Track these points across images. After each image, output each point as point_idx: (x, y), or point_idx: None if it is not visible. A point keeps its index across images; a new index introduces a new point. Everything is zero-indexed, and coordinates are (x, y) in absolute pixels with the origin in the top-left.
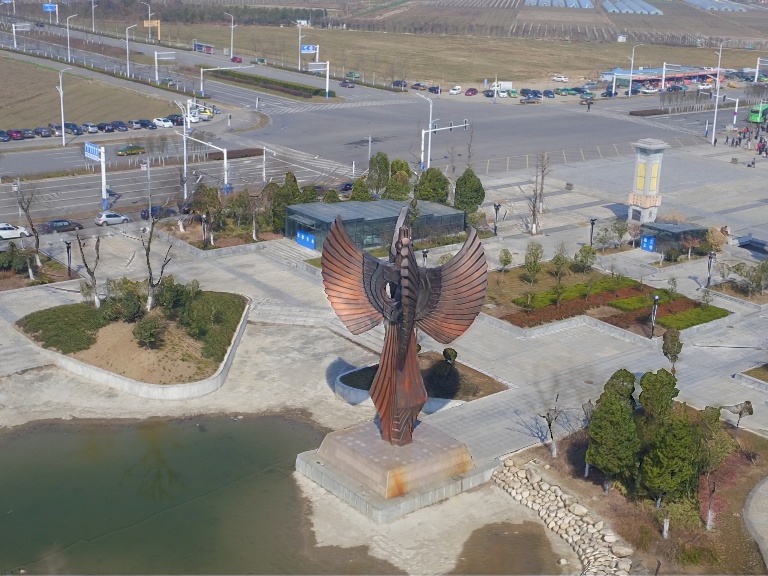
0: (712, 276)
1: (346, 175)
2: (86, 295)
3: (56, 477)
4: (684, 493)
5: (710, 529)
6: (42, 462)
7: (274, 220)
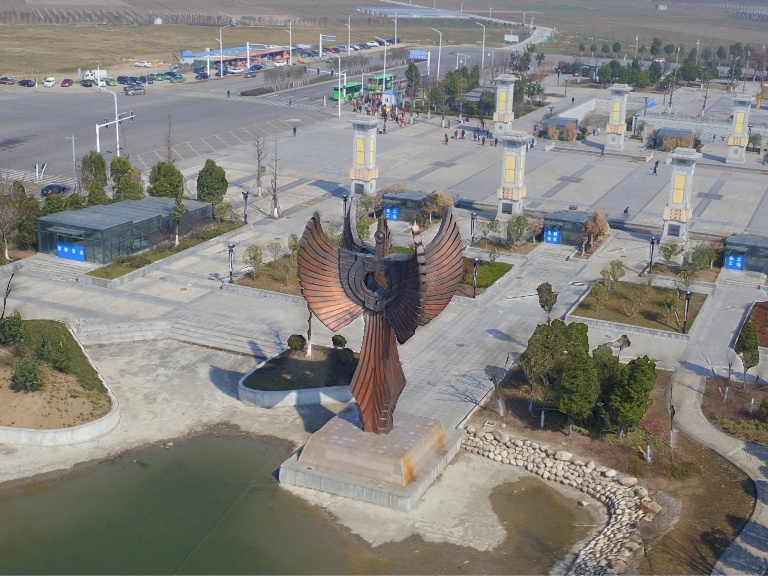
0: None
1: (25, 180)
2: None
3: (35, 551)
4: None
5: (673, 447)
6: (2, 539)
7: (24, 235)
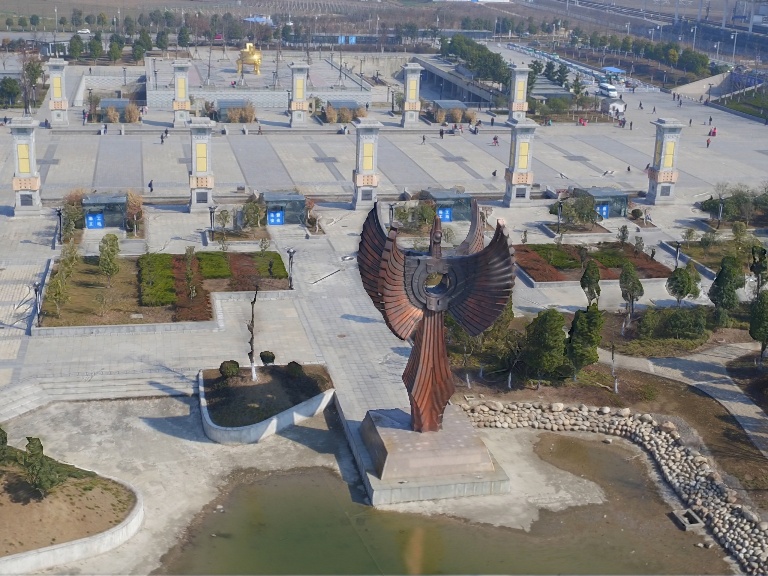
0: None
1: None
2: None
3: None
4: None
5: None
6: None
7: None
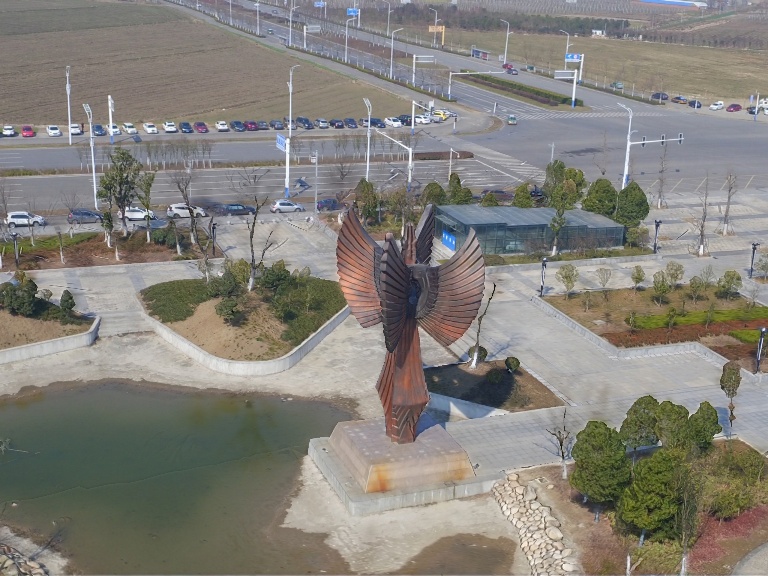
0: None
1: (542, 183)
2: (205, 272)
3: (97, 429)
4: (674, 534)
5: (684, 575)
6: (93, 415)
7: None
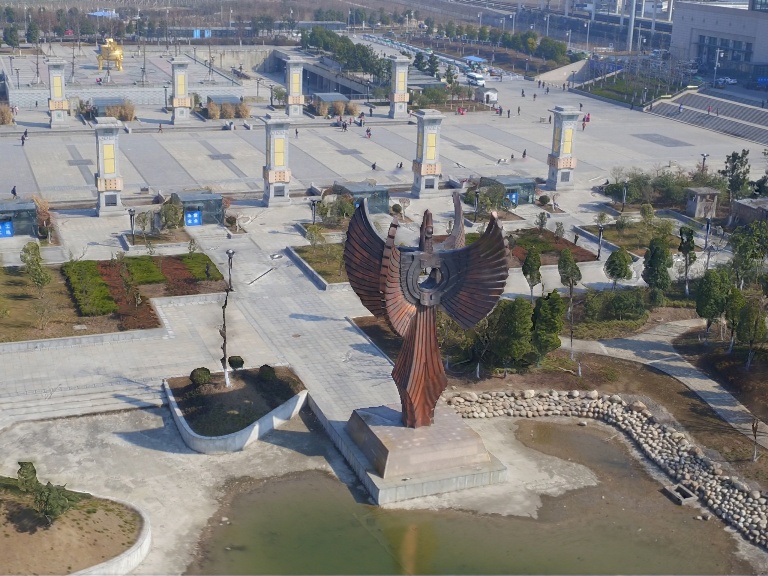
0: (135, 232)
1: None
2: None
3: None
4: None
5: (573, 360)
6: None
7: None
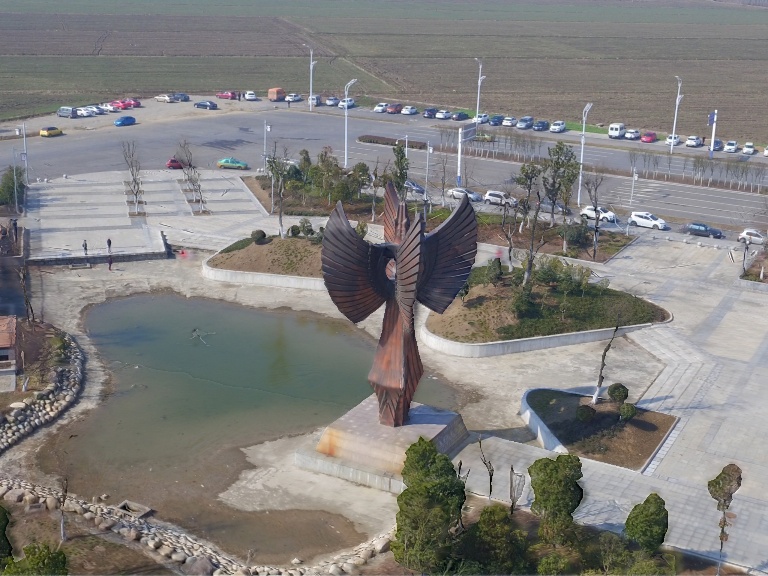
0: None
1: None
2: None
3: (273, 347)
4: None
5: None
6: (289, 338)
7: None
